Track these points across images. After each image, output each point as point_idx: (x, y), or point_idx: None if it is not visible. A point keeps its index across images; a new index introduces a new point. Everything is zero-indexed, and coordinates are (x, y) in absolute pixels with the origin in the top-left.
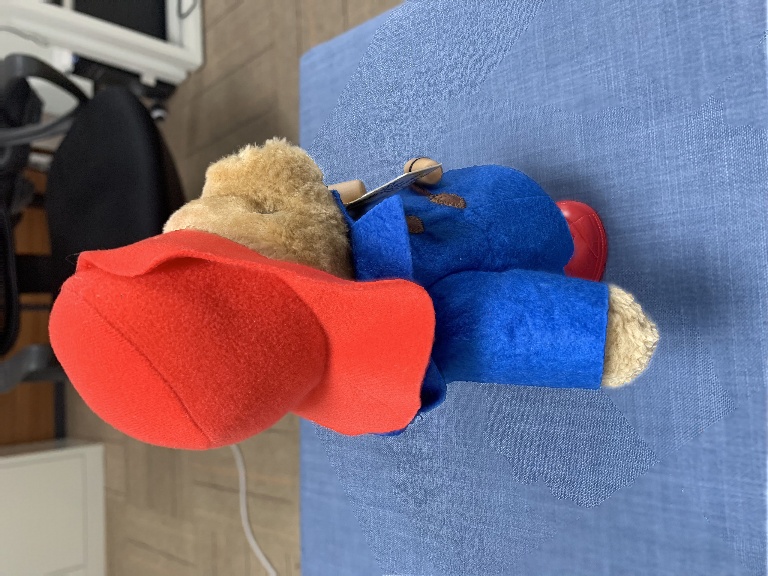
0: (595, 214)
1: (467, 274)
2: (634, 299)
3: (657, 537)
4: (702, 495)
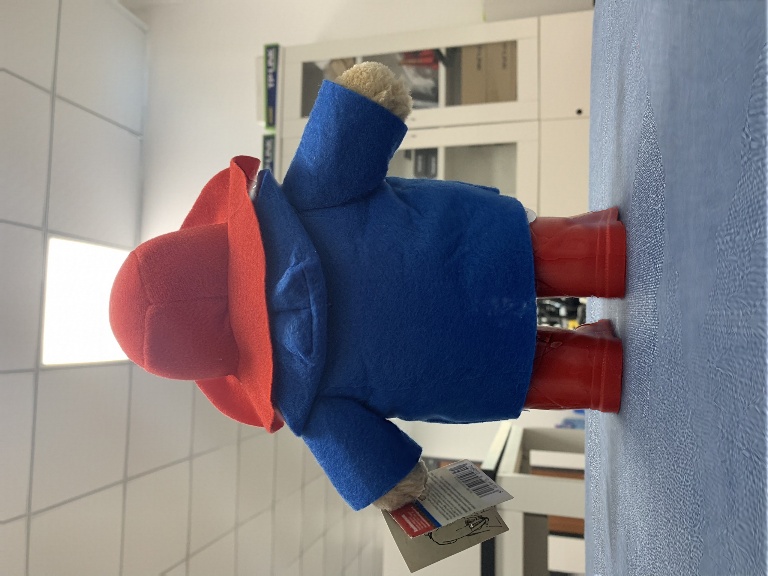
0: None
1: None
2: (619, 168)
3: None
4: (652, 12)
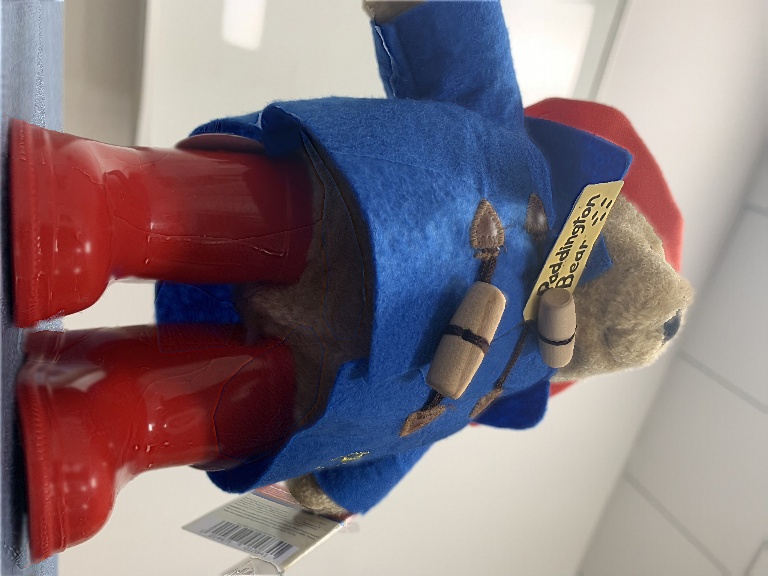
0: (11, 158)
1: (514, 124)
2: None
3: (46, 13)
4: None
